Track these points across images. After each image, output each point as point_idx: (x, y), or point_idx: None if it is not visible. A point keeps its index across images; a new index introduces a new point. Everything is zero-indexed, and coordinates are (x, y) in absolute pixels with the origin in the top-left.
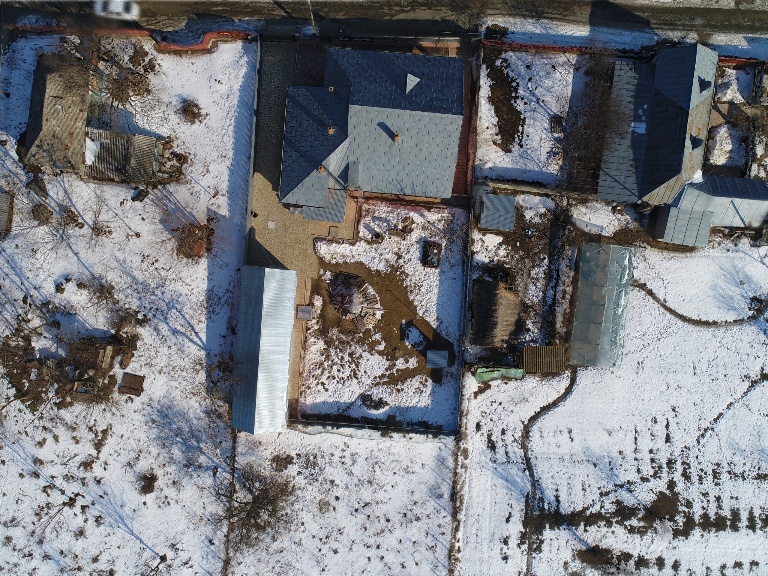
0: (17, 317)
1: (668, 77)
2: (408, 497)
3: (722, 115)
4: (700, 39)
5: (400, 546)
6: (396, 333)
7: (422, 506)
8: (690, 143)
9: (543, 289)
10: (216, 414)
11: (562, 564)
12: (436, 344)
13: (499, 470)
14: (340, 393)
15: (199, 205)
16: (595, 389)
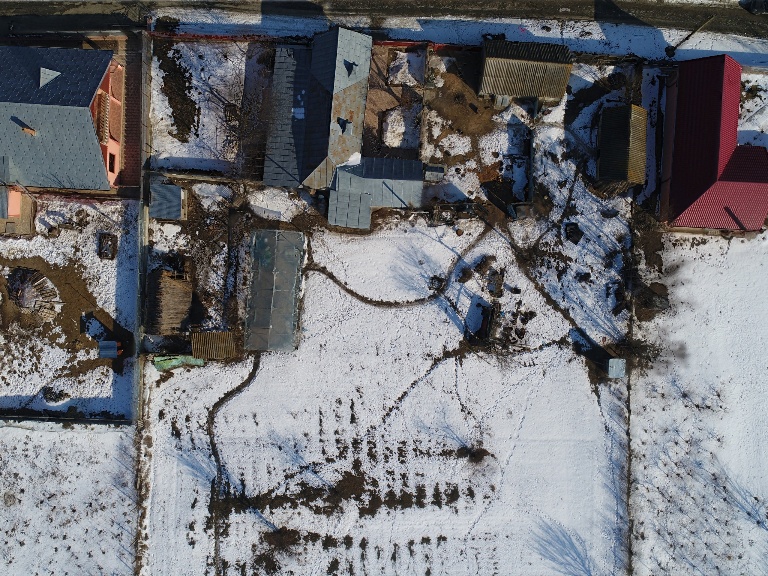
0: None
1: (320, 62)
2: (93, 487)
3: (396, 98)
4: (373, 23)
5: (86, 536)
6: (76, 325)
7: (107, 495)
8: (339, 126)
9: (223, 276)
10: None
11: (250, 547)
12: (116, 335)
13: (185, 457)
14: (22, 387)
15: None
16: (278, 373)
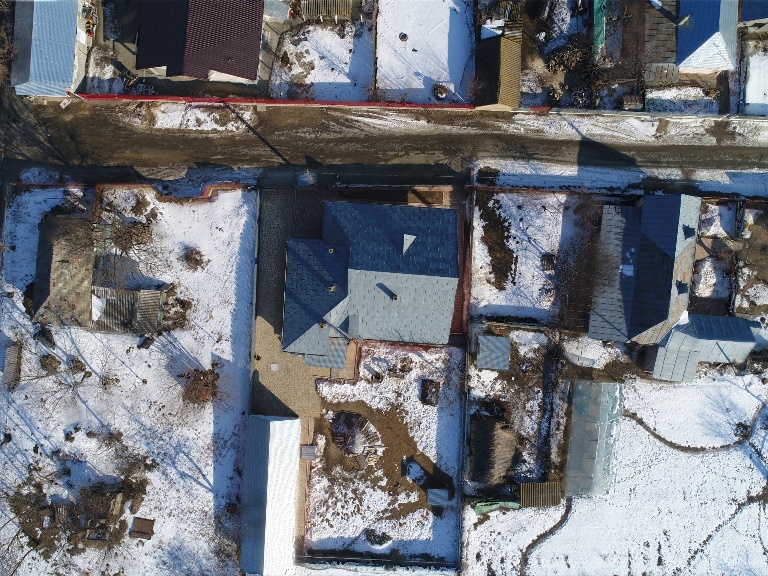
0: (28, 466)
1: (654, 223)
2: None
3: (706, 249)
4: (684, 175)
5: None
6: (397, 469)
7: None
8: (676, 289)
9: (538, 421)
10: (225, 553)
11: None
12: (436, 478)
13: None
14: (344, 529)
15: (203, 350)
16: (590, 516)
